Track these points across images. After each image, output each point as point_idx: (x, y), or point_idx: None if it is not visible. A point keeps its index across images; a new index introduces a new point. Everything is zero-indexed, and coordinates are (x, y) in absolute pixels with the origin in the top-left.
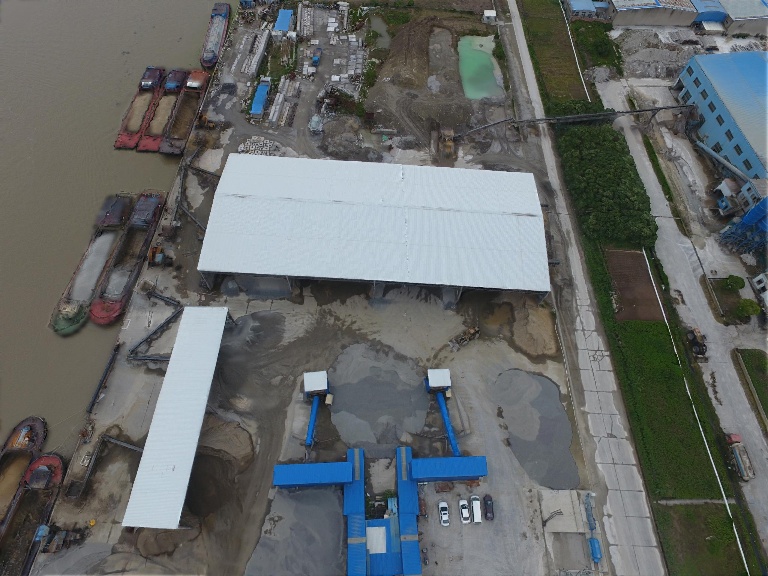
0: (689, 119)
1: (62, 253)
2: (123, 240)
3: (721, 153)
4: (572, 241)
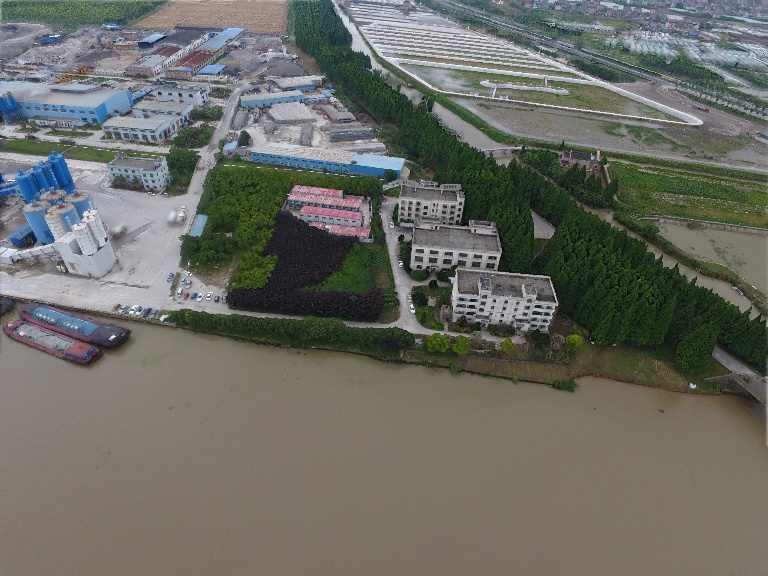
0: None
1: None
2: None
3: None
4: None
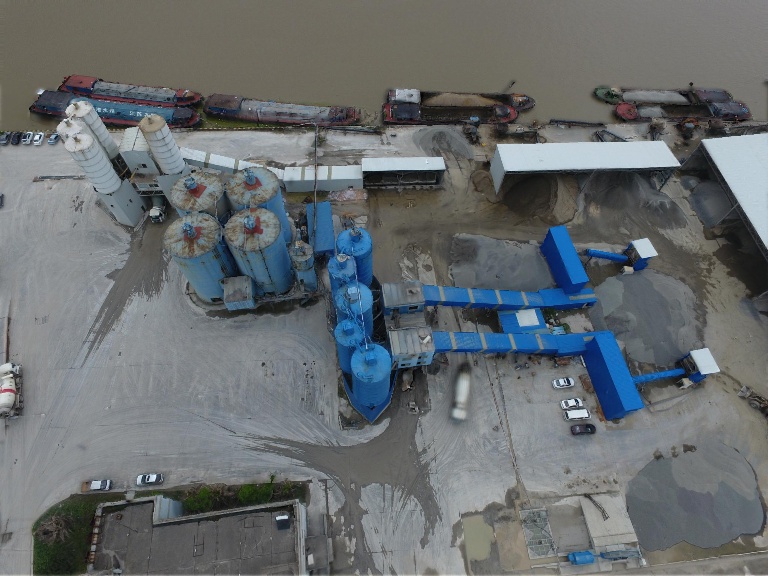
0: None
1: (654, 78)
2: (688, 105)
3: None
4: None
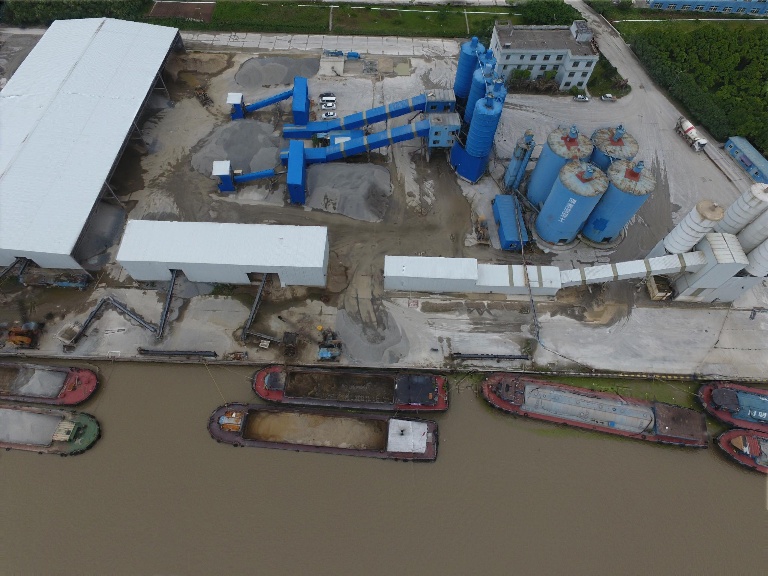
0: None
1: None
2: None
3: None
4: None
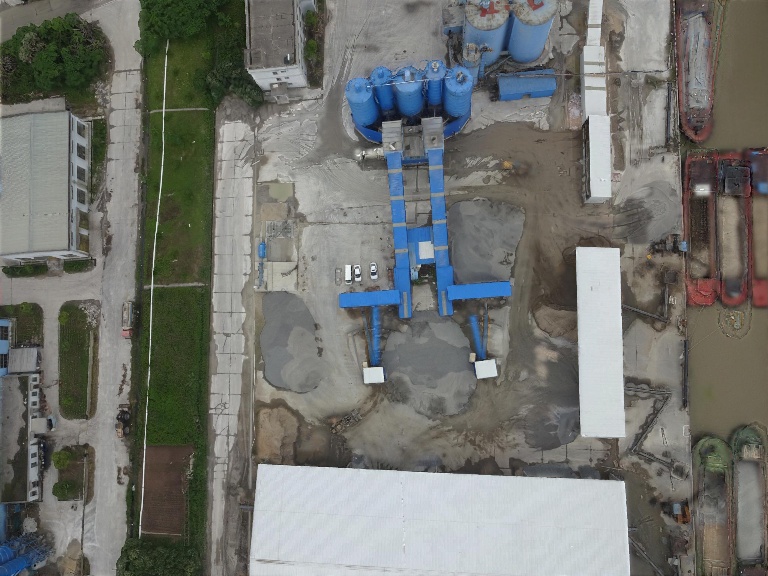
0: None
1: None
2: (729, 538)
3: None
4: (215, 547)
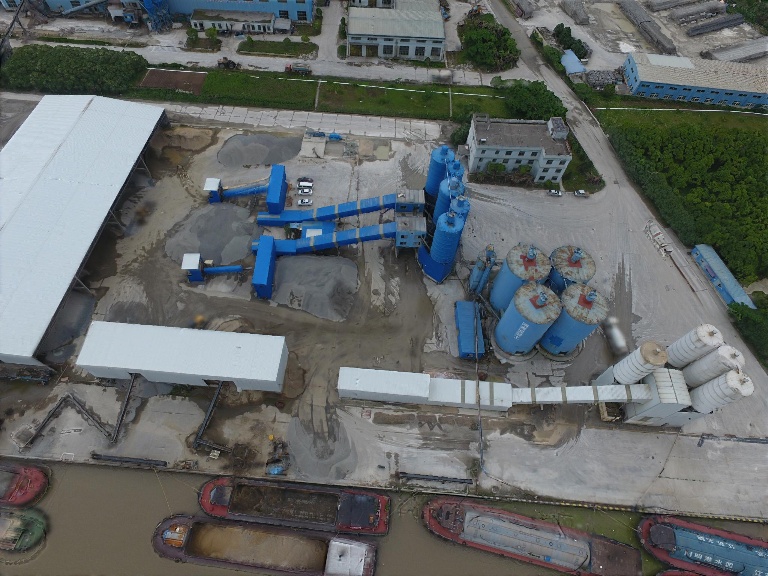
0: (37, 8)
1: None
2: None
3: (82, 4)
4: None
